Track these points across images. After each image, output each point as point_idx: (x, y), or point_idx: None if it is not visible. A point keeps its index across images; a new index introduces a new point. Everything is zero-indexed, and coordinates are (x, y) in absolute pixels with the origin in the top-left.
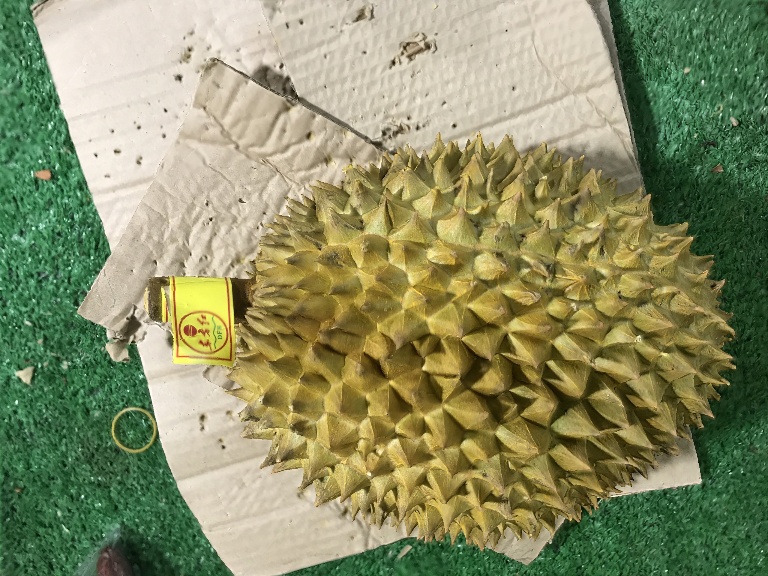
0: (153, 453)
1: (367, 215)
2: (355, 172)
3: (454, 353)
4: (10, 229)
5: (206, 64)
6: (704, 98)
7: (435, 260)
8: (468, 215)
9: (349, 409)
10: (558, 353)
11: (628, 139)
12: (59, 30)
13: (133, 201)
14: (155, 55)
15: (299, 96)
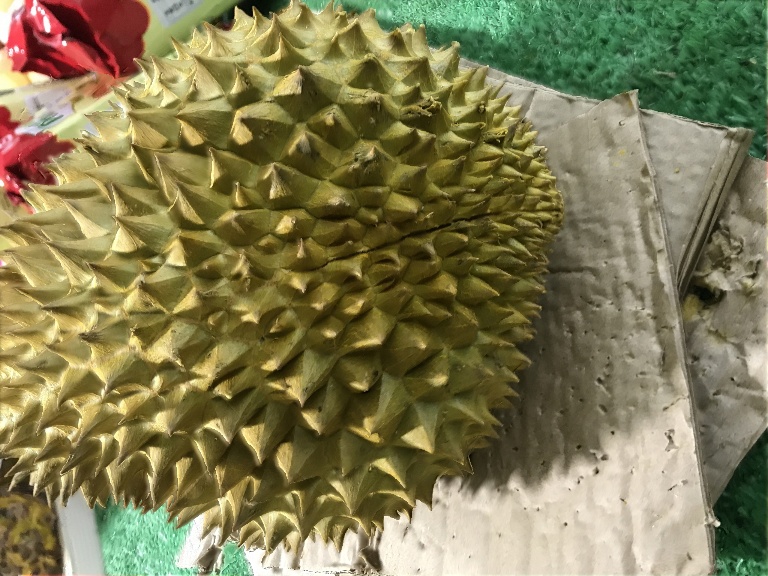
0: None
1: None
2: None
3: None
4: None
5: None
6: None
7: None
8: None
9: None
10: None
11: None
12: None
13: None
14: None
15: None
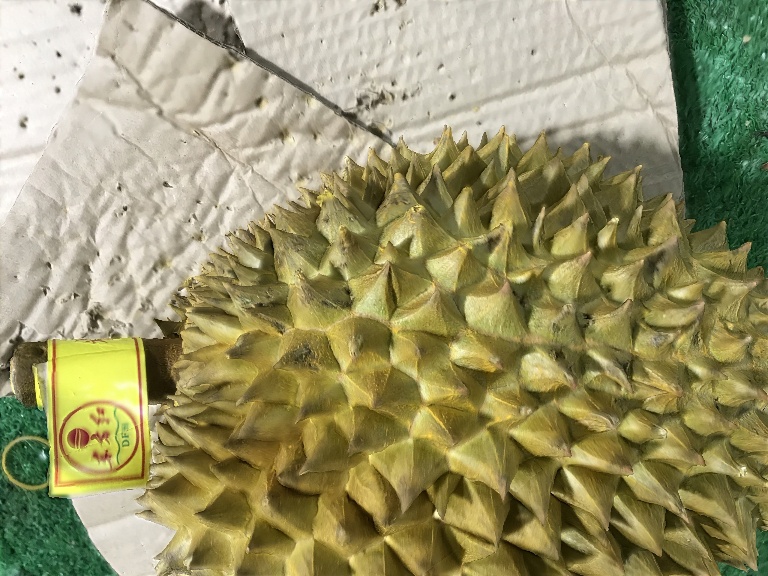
0: None
1: (357, 283)
2: (336, 204)
3: (485, 503)
4: None
5: None
6: (762, 76)
7: (463, 363)
8: (510, 285)
9: None
10: (629, 489)
11: (674, 129)
12: None
13: (17, 177)
14: None
15: (246, 46)
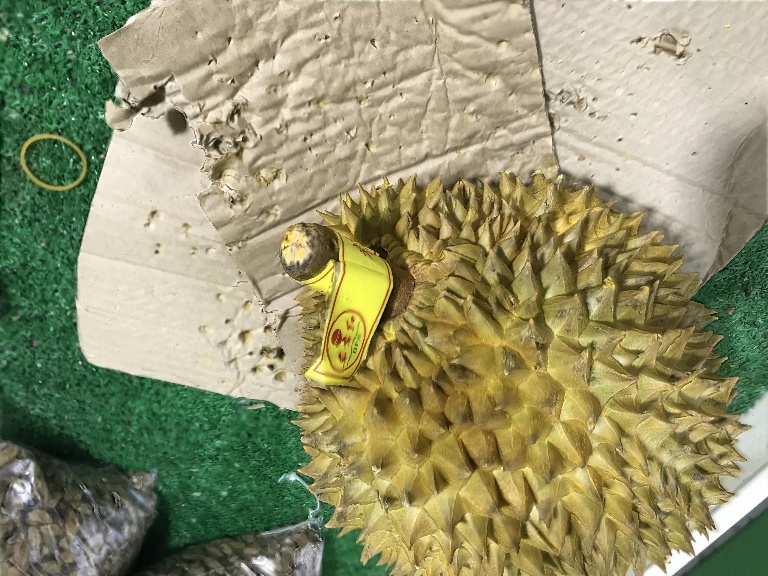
0: (61, 197)
1: (602, 369)
2: (612, 295)
3: (563, 522)
4: None
5: None
6: None
7: None
8: None
9: None
10: None
11: (720, 267)
12: None
13: None
14: None
15: None
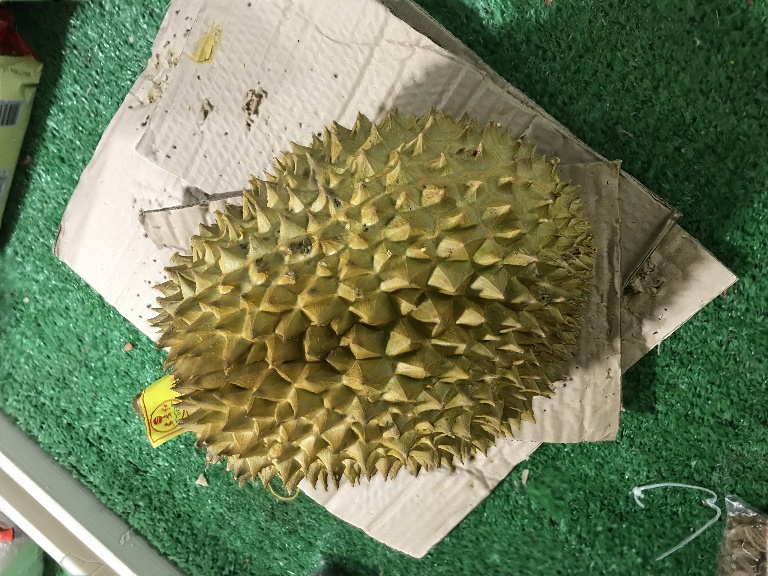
0: None
1: None
2: (177, 257)
3: (271, 347)
4: (135, 393)
5: (139, 221)
6: None
7: (225, 292)
8: (238, 243)
9: (233, 424)
10: (346, 300)
11: (436, 47)
12: (74, 255)
13: None
14: (127, 230)
15: (211, 194)
